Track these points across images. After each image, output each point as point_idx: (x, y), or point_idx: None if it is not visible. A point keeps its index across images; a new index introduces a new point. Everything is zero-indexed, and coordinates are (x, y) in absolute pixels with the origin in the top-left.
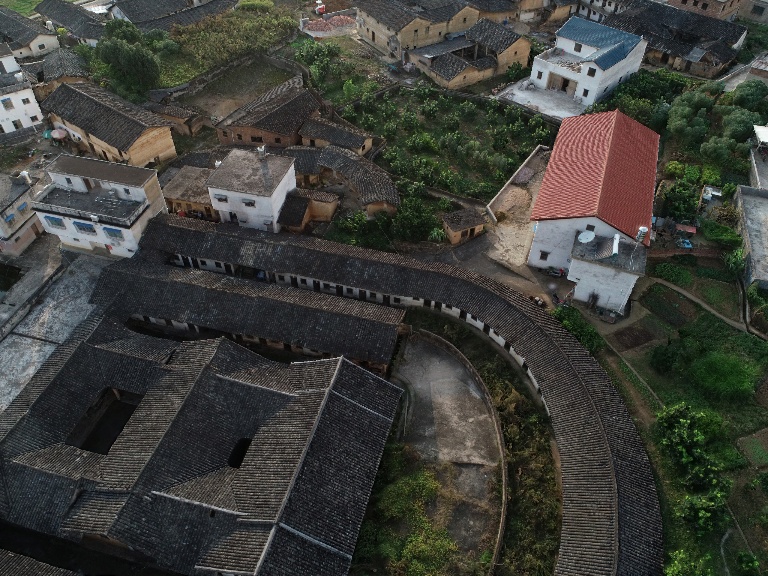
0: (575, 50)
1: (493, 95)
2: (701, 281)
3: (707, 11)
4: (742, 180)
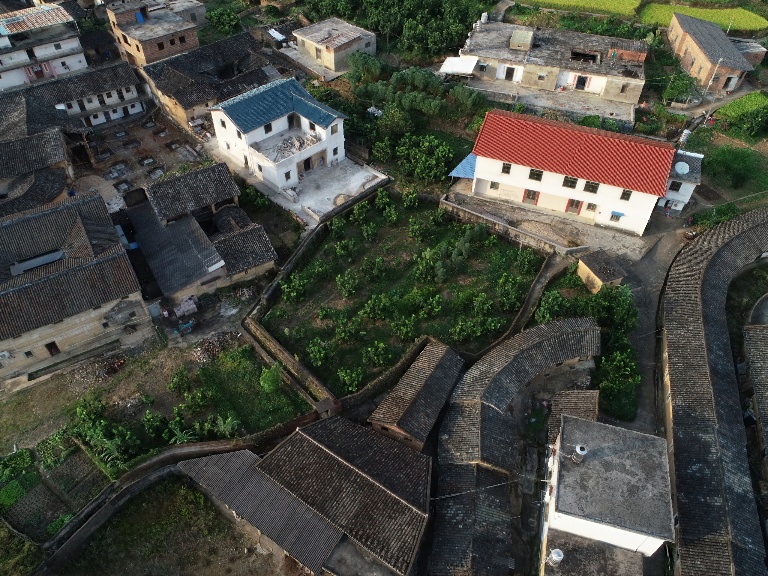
0: (266, 133)
1: (307, 225)
2: None
3: (187, 42)
4: (492, 103)
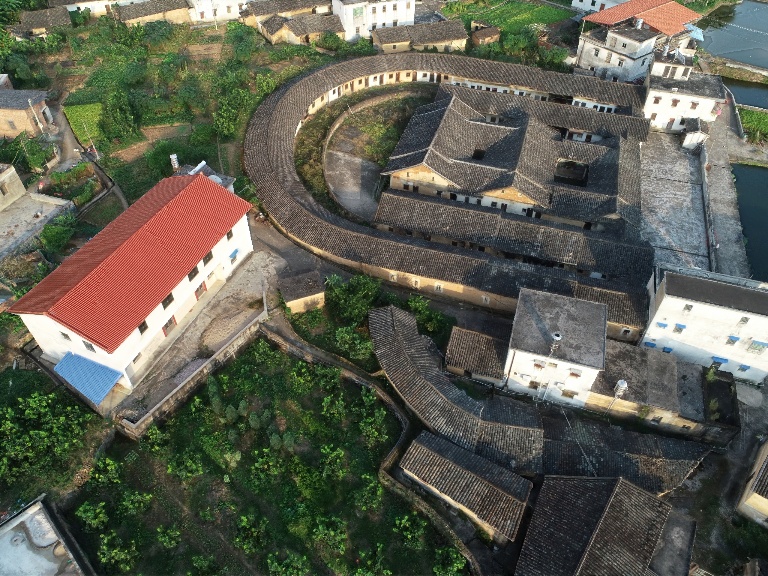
0: None
1: None
2: (107, 224)
3: None
4: None
